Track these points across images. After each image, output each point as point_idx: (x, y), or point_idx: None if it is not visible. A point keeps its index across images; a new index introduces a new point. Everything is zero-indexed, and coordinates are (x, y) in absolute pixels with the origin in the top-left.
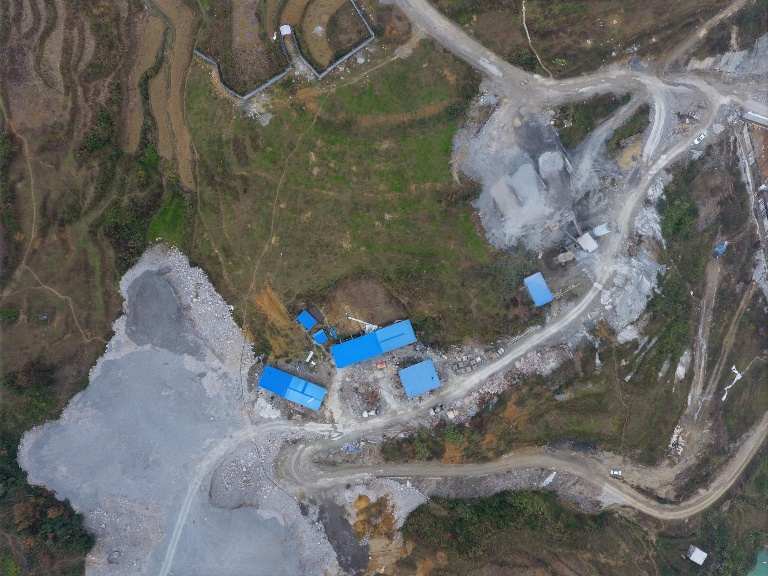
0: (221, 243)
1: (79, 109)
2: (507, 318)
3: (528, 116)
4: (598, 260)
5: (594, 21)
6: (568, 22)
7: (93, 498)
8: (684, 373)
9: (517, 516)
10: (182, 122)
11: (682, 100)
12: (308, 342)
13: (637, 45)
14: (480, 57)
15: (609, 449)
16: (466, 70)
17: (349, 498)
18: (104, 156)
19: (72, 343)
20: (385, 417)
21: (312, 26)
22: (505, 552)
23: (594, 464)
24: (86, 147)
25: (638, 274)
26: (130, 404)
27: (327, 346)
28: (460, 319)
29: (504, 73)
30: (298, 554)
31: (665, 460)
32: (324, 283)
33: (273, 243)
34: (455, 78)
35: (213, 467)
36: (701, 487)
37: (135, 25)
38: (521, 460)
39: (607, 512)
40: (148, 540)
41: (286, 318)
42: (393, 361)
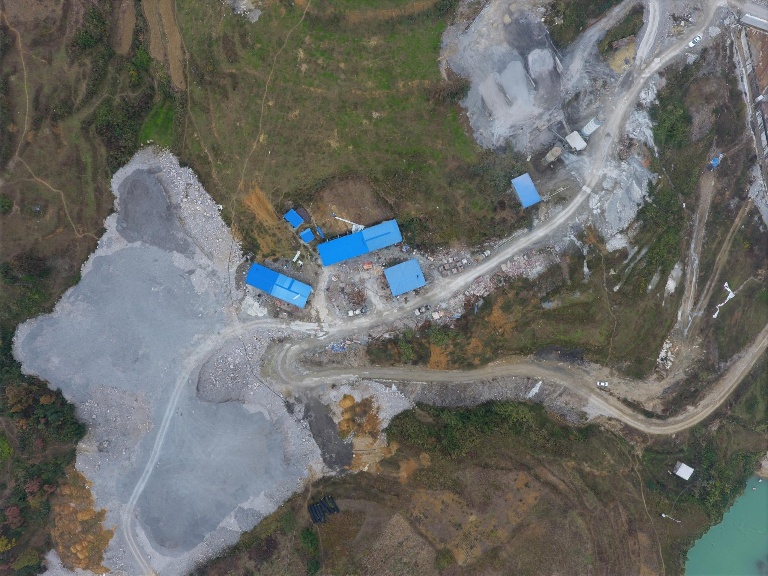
0: (210, 143)
1: (72, 6)
2: (494, 220)
3: (518, 13)
4: (587, 163)
5: None
6: None
7: (84, 388)
8: (674, 287)
9: (502, 423)
10: (173, 23)
11: (677, 1)
12: (295, 242)
13: None
14: None
15: (596, 360)
16: None
17: (334, 397)
18: (96, 54)
19: (64, 237)
20: (371, 317)
21: None
22: (488, 455)
23: (581, 375)
24: (78, 44)
25: (628, 178)
26: (120, 299)
27: (314, 246)
28: (447, 221)
29: None
30: (283, 448)
31: (653, 374)
32: (311, 182)
33: (261, 141)
34: None
35: (201, 362)
36: (689, 404)
37: None
38: (507, 368)
39: (593, 425)
40: (137, 430)
41: (274, 218)
42: (379, 262)
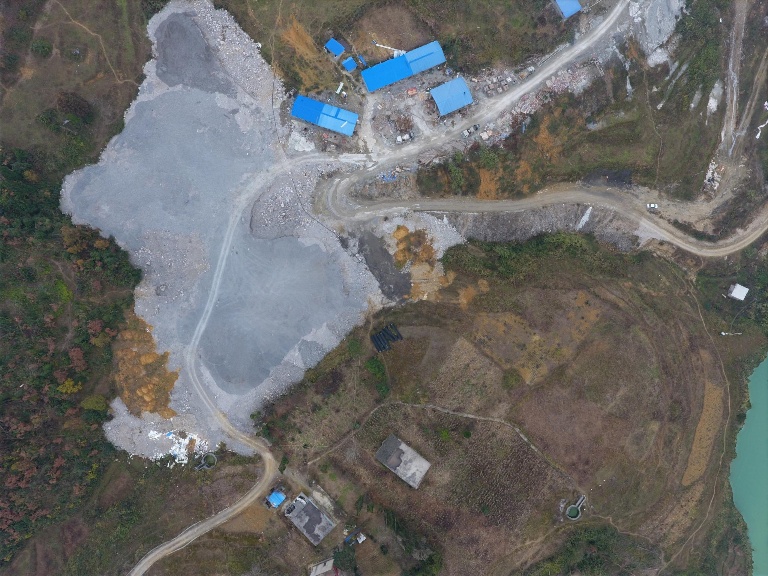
0: None
1: None
2: (535, 36)
3: None
4: None
5: None
6: None
7: (137, 233)
8: (716, 105)
9: (555, 249)
10: None
11: None
12: (337, 74)
13: None
14: None
15: (644, 183)
16: None
17: (388, 229)
18: None
19: (105, 83)
20: (419, 144)
21: None
22: (546, 277)
23: (630, 199)
24: None
25: None
26: (166, 143)
27: (357, 76)
28: (488, 40)
29: None
30: (341, 278)
31: (701, 195)
32: (350, 9)
33: None
34: None
35: (252, 200)
36: (739, 226)
37: None
38: (556, 196)
39: (645, 251)
40: (193, 271)
41: (314, 51)
42: (423, 87)
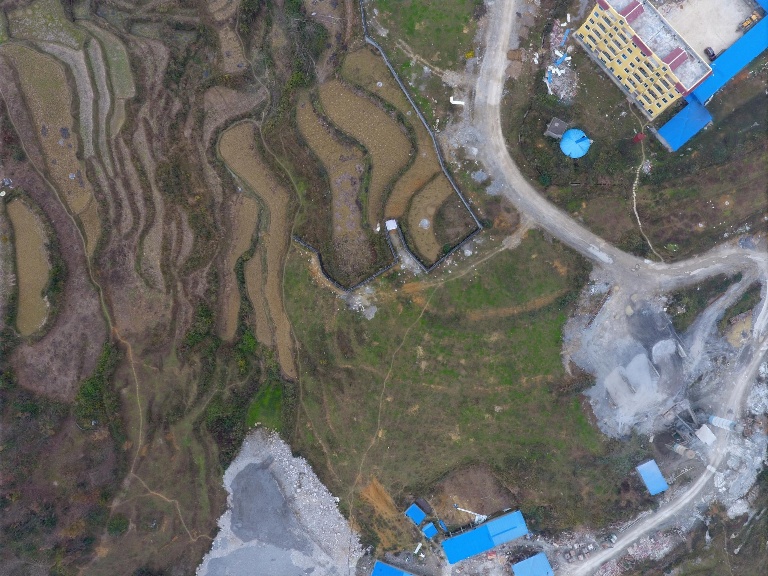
0: (325, 434)
1: (180, 306)
2: (619, 504)
3: (640, 304)
4: None
5: (705, 203)
6: (680, 207)
7: None
8: None
9: None
10: (281, 308)
11: None
12: (416, 533)
13: (749, 224)
14: (590, 244)
15: None
16: (577, 260)
17: None
18: (205, 350)
19: (179, 545)
20: None
21: (418, 219)
22: None
23: None
24: (188, 344)
25: (753, 456)
26: None
27: (436, 537)
28: (571, 506)
29: (614, 259)
30: None
31: None
32: (433, 476)
33: (380, 437)
34: (566, 270)
35: None
36: None
37: (229, 208)
38: None
39: None
40: None
41: (393, 509)
42: (503, 551)
